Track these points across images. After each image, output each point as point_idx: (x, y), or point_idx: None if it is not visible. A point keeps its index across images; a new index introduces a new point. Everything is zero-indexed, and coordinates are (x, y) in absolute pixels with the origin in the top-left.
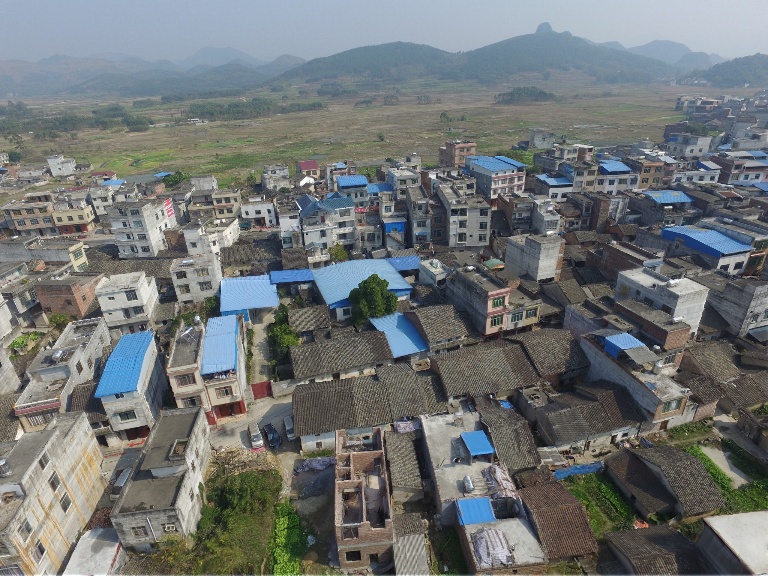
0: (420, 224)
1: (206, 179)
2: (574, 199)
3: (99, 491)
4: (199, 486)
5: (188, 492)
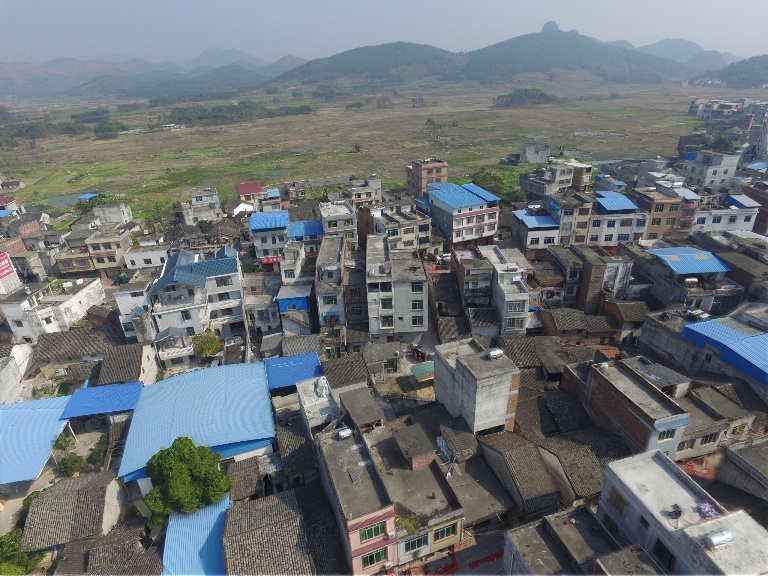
0: (328, 300)
1: (112, 209)
2: (555, 257)
3: None
4: None
5: None
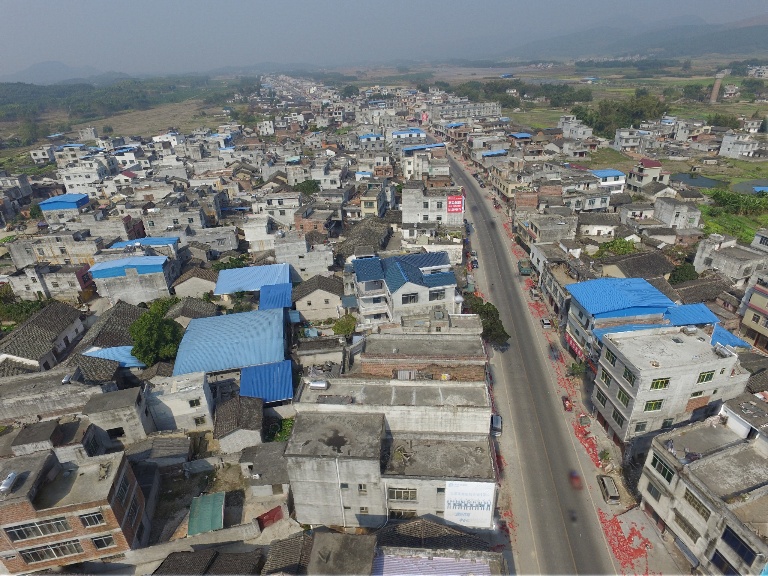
0: None
1: (669, 206)
2: None
3: None
4: (38, 291)
5: (24, 283)
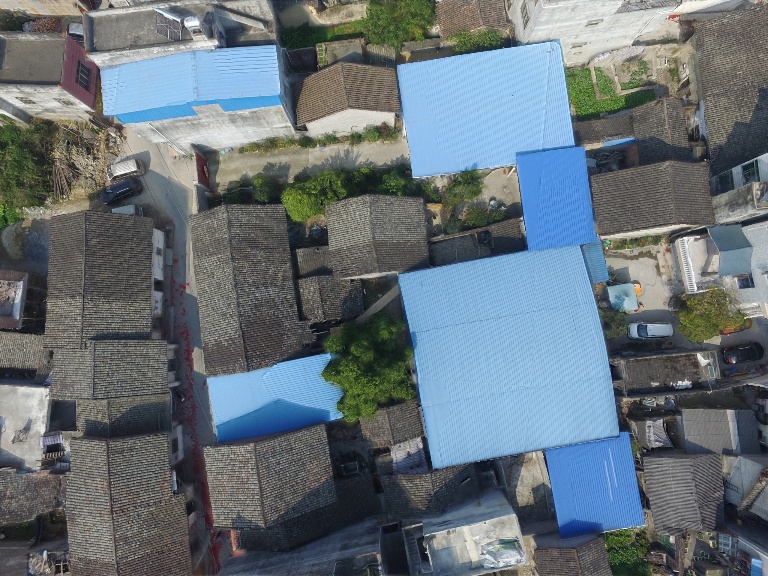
0: None
1: None
2: None
3: (72, 10)
4: None
5: None
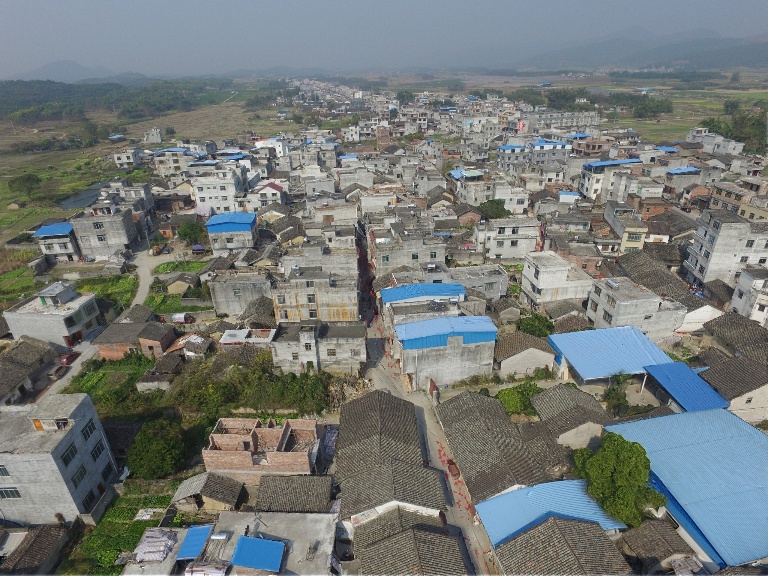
0: None
1: None
2: None
3: None
4: (309, 362)
5: (292, 351)
